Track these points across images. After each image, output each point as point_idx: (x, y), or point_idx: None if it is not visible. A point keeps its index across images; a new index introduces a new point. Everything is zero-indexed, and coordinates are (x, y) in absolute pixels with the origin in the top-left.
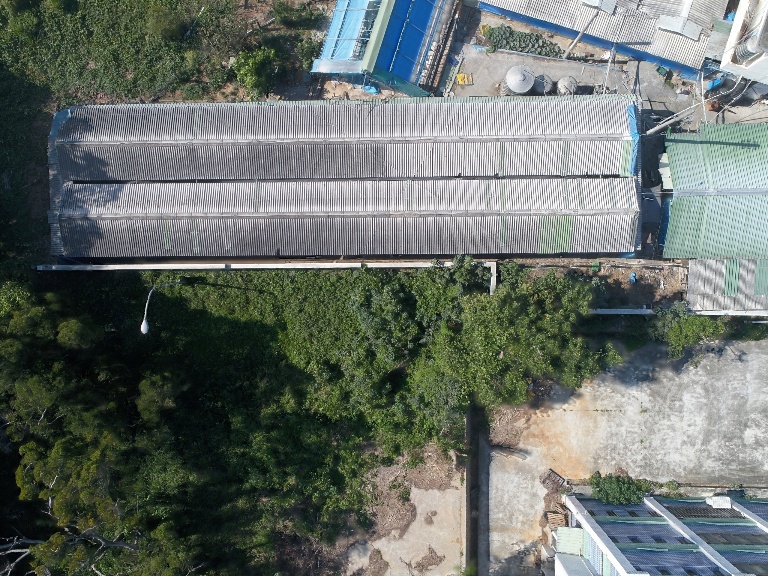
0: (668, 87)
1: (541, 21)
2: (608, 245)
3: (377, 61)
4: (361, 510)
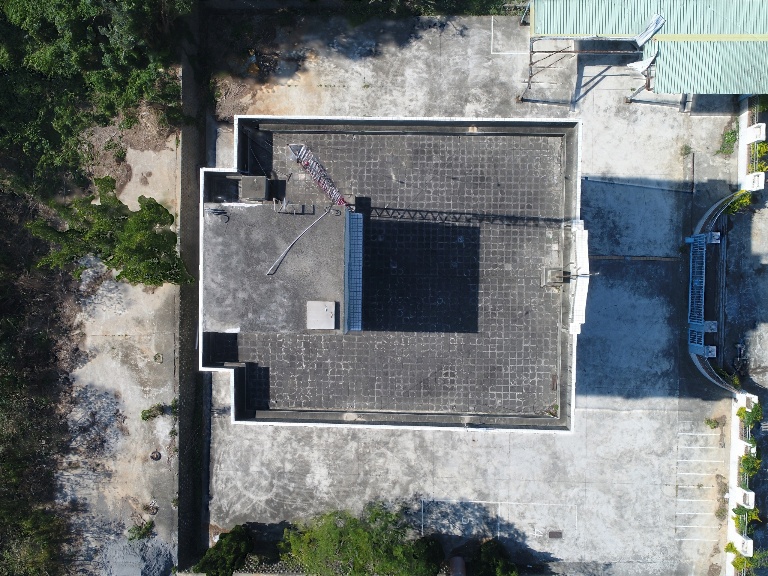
0: None
1: None
2: None
3: None
4: (77, 169)
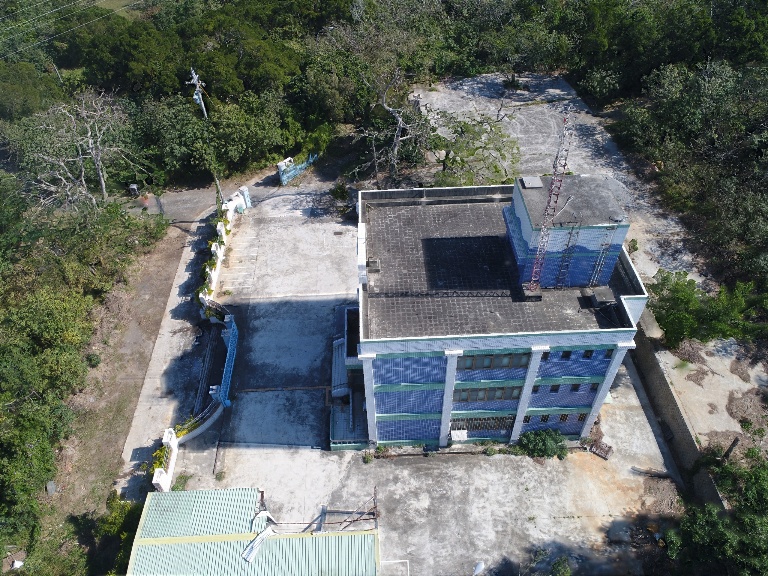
0: None
1: None
2: None
3: None
4: None
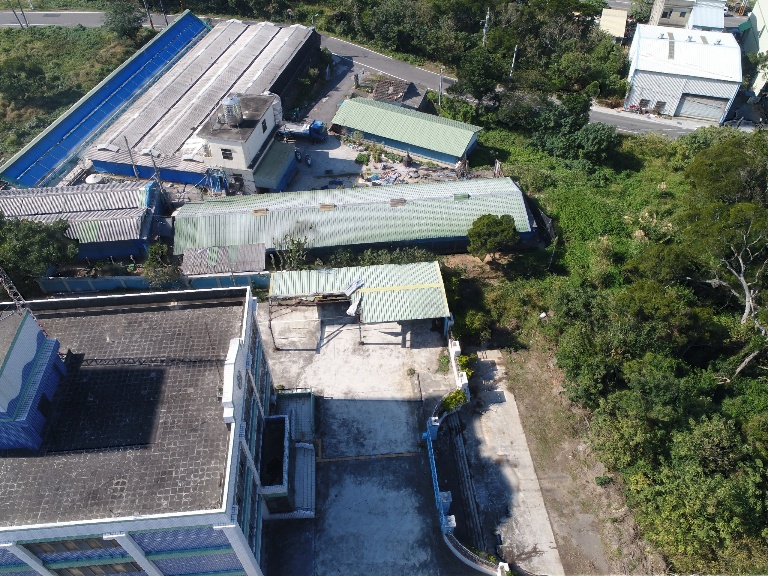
0: (203, 195)
1: (126, 169)
2: (122, 236)
3: (7, 172)
4: None
